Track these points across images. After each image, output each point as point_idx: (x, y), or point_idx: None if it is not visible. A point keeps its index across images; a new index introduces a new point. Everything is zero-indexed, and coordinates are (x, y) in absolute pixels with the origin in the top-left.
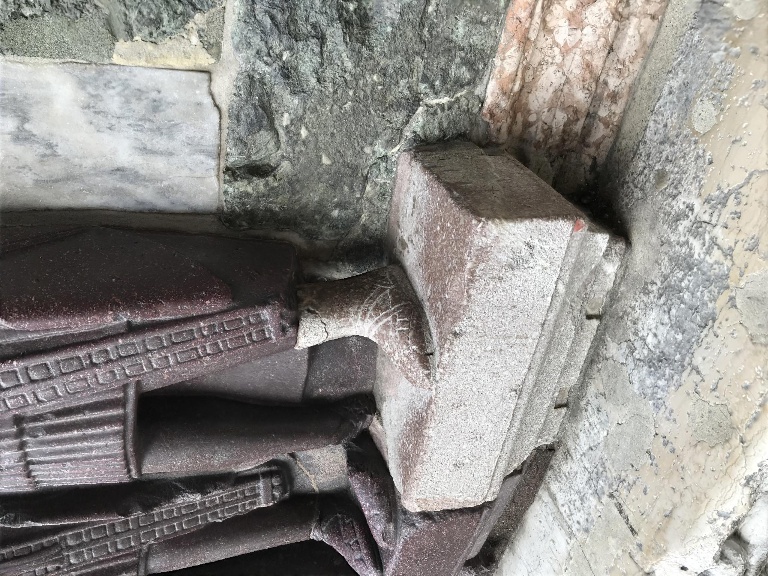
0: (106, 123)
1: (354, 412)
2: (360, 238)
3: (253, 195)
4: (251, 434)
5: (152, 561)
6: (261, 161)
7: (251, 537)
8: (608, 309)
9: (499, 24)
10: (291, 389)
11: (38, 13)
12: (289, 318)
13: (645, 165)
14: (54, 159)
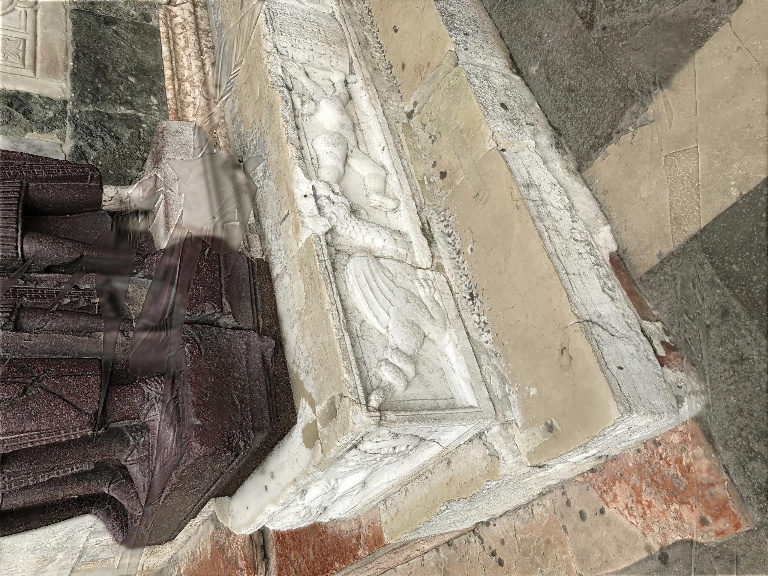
0: None
1: None
2: None
3: None
4: None
5: (23, 312)
6: None
7: (91, 315)
8: None
9: None
10: None
11: (1, 125)
12: None
13: None
14: None
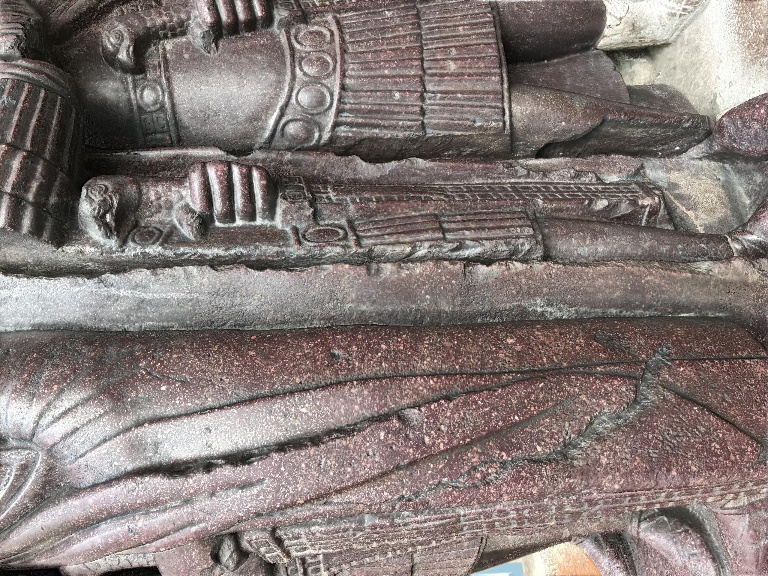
0: None
1: None
2: None
3: None
4: None
5: (544, 226)
6: None
7: (652, 229)
8: None
9: None
10: None
11: None
12: None
13: None
14: None
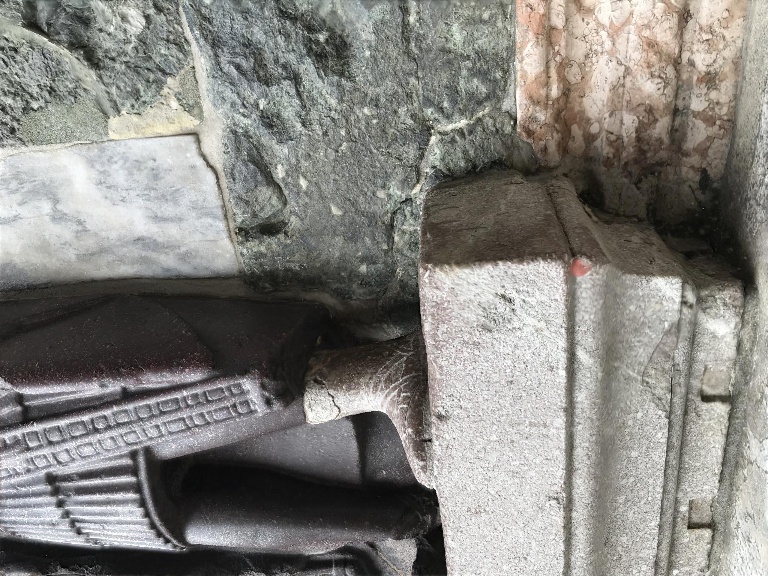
0: (118, 196)
1: (422, 502)
2: (401, 296)
3: (268, 255)
4: (296, 515)
5: None
6: (276, 218)
7: None
8: (744, 387)
9: (508, 19)
10: (347, 468)
11: (43, 105)
12: (273, 389)
13: (764, 171)
14: (86, 234)
